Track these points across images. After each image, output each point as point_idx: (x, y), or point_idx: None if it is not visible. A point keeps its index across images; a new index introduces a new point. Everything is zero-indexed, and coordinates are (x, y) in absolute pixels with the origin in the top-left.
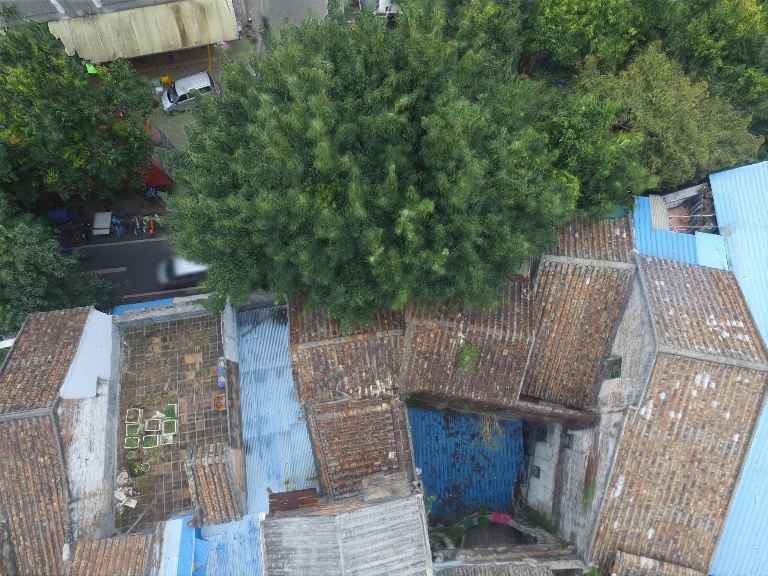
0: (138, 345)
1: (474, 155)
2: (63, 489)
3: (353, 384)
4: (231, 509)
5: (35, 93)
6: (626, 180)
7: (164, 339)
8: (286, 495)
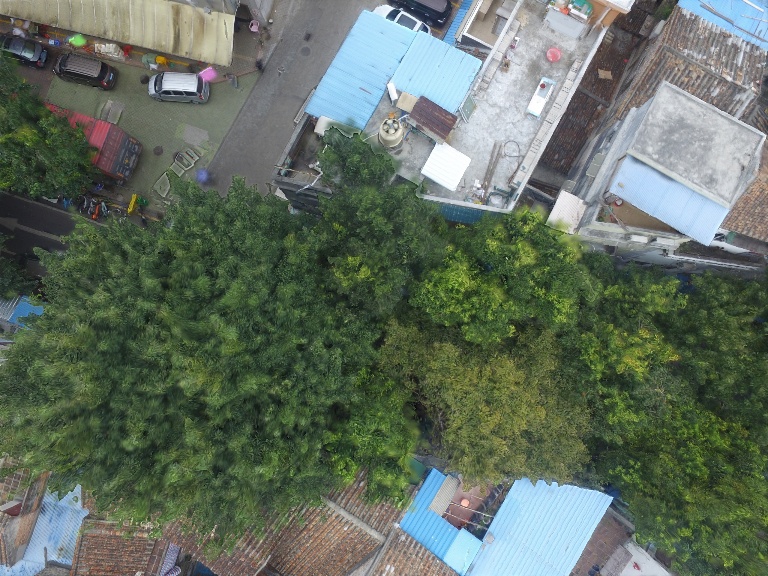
0: None
1: (211, 474)
2: None
3: None
4: (5, 558)
5: None
6: (389, 494)
7: None
8: None
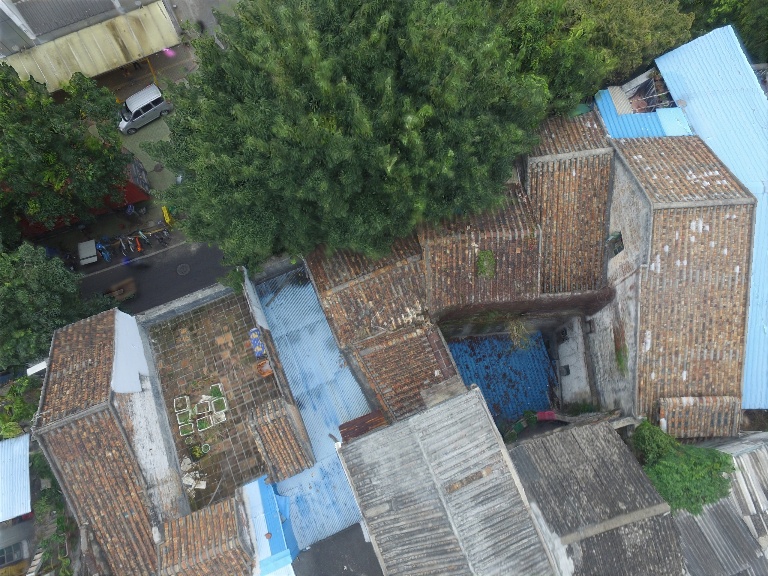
0: (167, 340)
1: None
2: (138, 477)
3: (386, 317)
4: (301, 458)
5: (5, 118)
6: (587, 69)
7: (191, 328)
8: (354, 422)
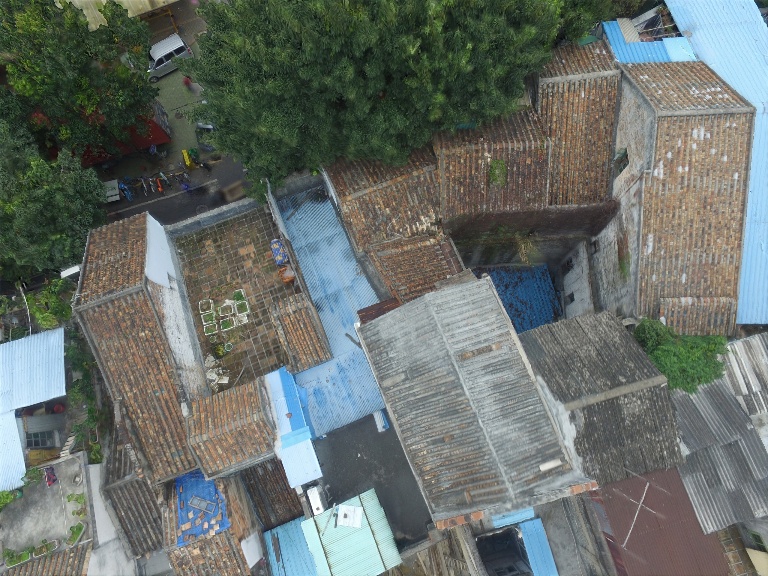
0: (192, 250)
1: None
2: (168, 356)
3: (401, 224)
4: (320, 350)
5: (45, 34)
6: None
7: (215, 240)
8: (372, 308)
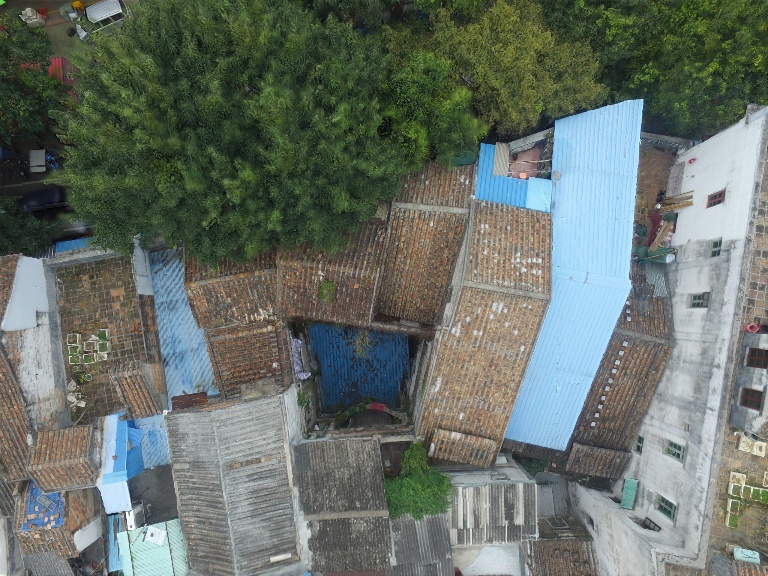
0: (70, 282)
1: (293, 135)
2: (19, 397)
3: (241, 312)
4: (153, 407)
5: None
6: (452, 140)
7: (91, 276)
8: (184, 397)
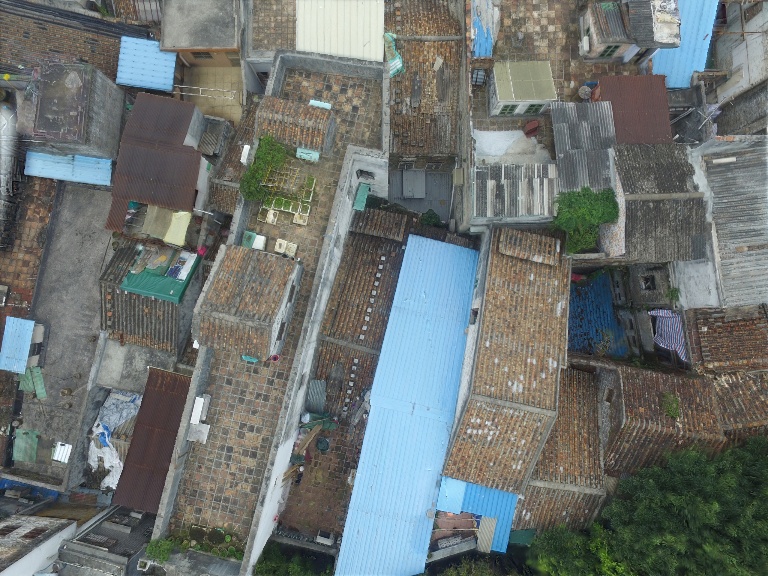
0: None
1: None
2: None
3: (747, 384)
4: None
5: None
6: (570, 568)
7: None
8: None
